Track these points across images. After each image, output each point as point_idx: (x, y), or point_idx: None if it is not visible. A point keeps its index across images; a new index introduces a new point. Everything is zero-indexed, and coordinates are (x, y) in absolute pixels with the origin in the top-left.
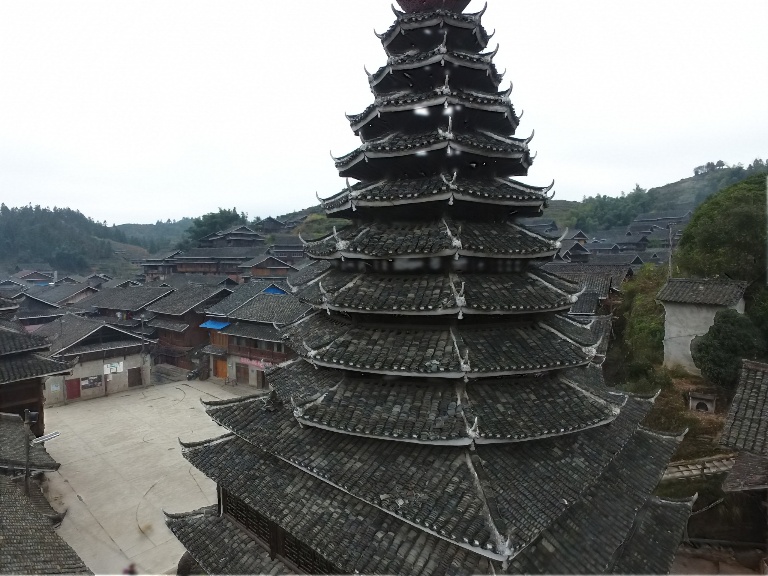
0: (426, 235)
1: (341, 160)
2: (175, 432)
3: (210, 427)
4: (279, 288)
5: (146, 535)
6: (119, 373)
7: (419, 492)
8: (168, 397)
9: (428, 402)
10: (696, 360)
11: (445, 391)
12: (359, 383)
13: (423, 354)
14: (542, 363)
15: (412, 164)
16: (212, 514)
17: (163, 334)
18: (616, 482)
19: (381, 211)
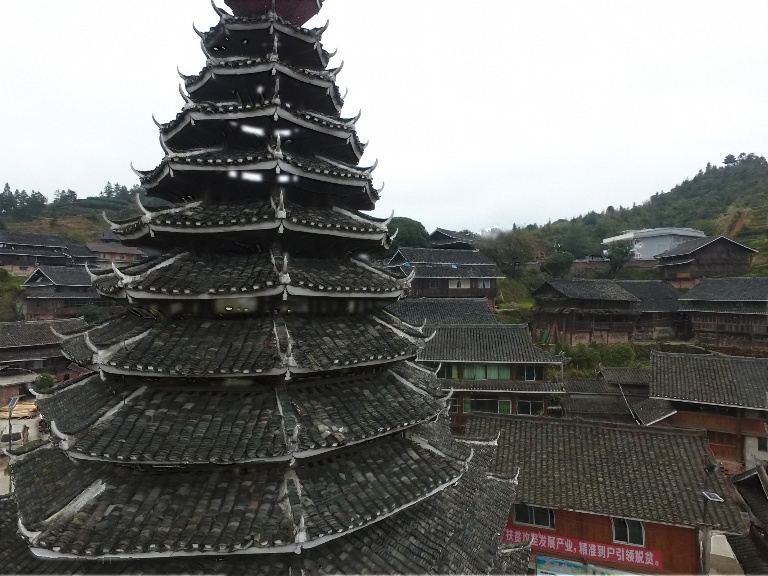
0: None
1: None
2: None
3: None
4: None
5: None
6: None
7: None
8: None
9: None
10: None
11: None
12: None
13: None
14: None
15: None
16: None
17: None
18: None
19: None
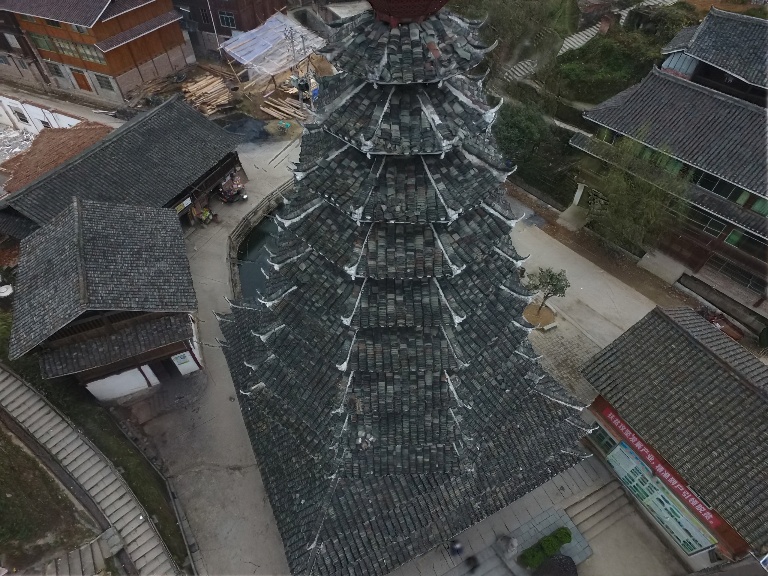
0: None
1: None
2: None
3: None
4: None
5: None
6: None
7: None
8: None
9: None
10: None
11: None
12: None
13: None
14: None
15: None
16: None
17: None
18: None
19: None
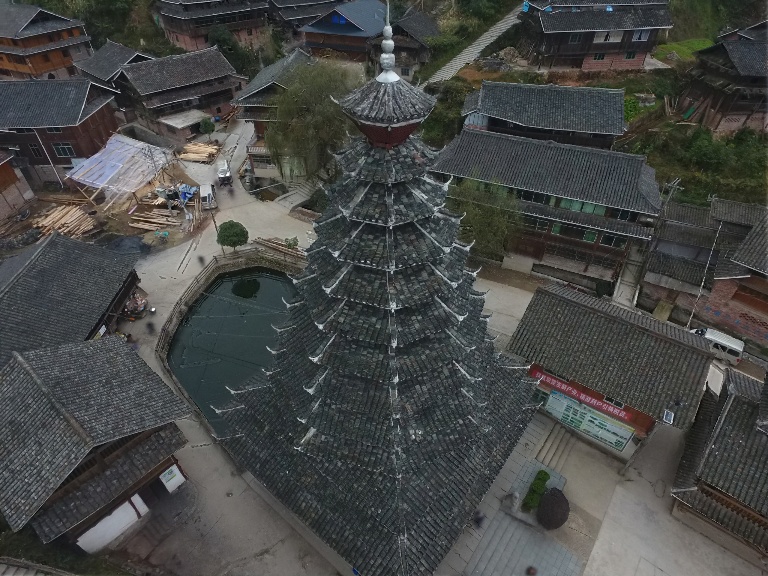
0: None
1: None
2: None
3: None
4: None
5: None
6: None
7: None
8: None
9: None
10: None
11: None
12: None
13: None
14: None
15: None
16: None
17: None
18: None
19: None
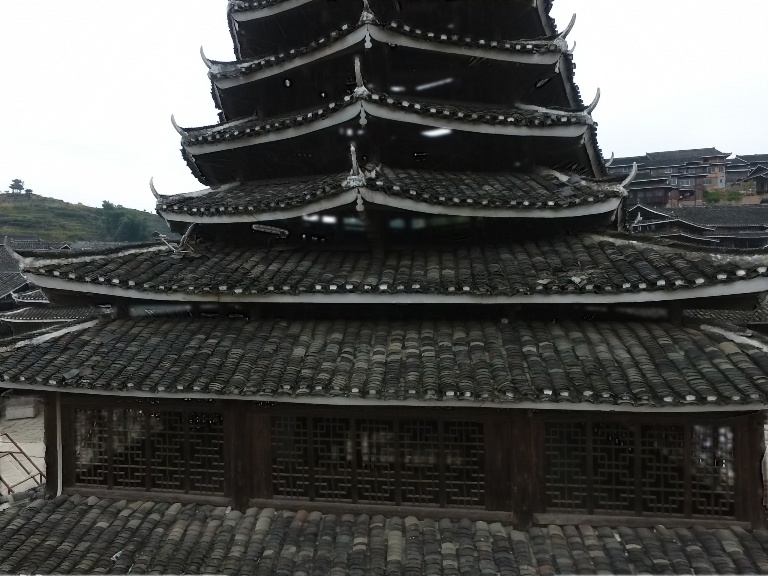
0: None
1: None
2: None
3: None
4: None
5: None
6: None
7: (580, 271)
8: None
9: (523, 182)
10: None
11: (530, 175)
12: (406, 171)
13: None
14: None
15: None
16: (32, 498)
17: None
18: None
19: None
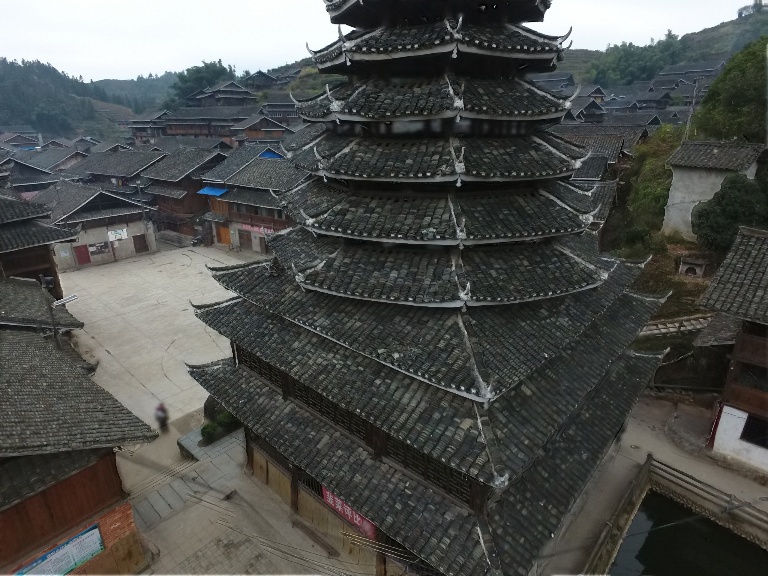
0: (426, 94)
1: (333, 1)
2: (187, 295)
3: (219, 290)
4: (275, 152)
5: (173, 382)
6: (124, 240)
7: (413, 347)
8: (176, 263)
9: (424, 268)
10: (694, 226)
11: (441, 258)
12: (358, 250)
13: (420, 222)
14: (537, 230)
15: (413, 7)
16: (229, 365)
17: (162, 201)
18: (595, 339)
19: (378, 65)
